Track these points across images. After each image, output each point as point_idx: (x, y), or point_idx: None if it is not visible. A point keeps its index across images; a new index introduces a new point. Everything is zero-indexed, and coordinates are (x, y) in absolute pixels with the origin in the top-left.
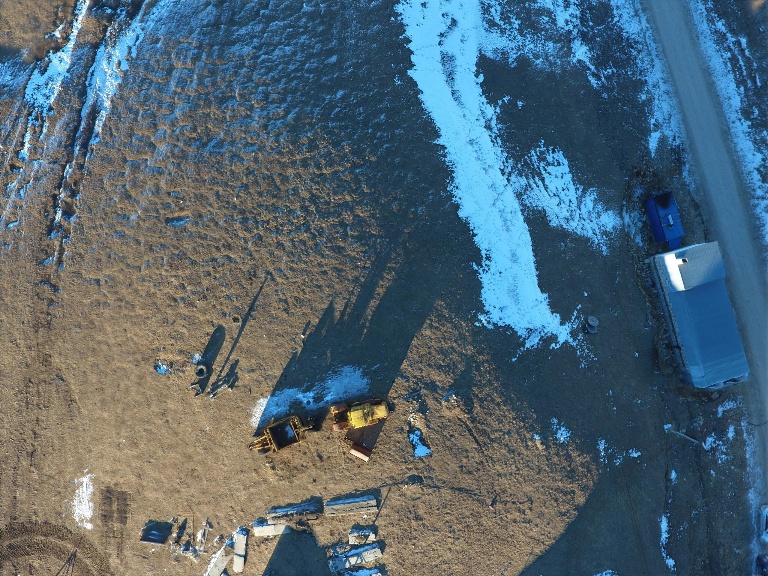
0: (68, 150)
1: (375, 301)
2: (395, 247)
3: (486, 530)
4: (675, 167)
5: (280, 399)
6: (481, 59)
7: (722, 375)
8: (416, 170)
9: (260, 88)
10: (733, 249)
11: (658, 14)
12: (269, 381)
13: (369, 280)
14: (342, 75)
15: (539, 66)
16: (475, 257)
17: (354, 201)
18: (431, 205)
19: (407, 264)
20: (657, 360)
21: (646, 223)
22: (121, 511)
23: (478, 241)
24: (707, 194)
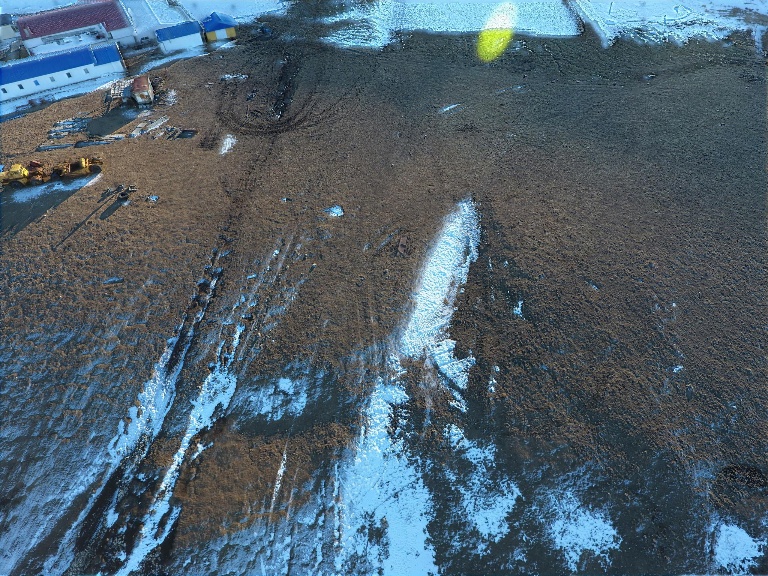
0: (198, 331)
1: None
2: None
3: None
4: None
5: (77, 185)
6: None
7: None
8: None
9: (6, 392)
10: None
11: None
12: (80, 193)
13: None
14: None
15: None
16: None
17: None
18: None
19: None
20: None
21: None
22: (207, 141)
23: None
24: None
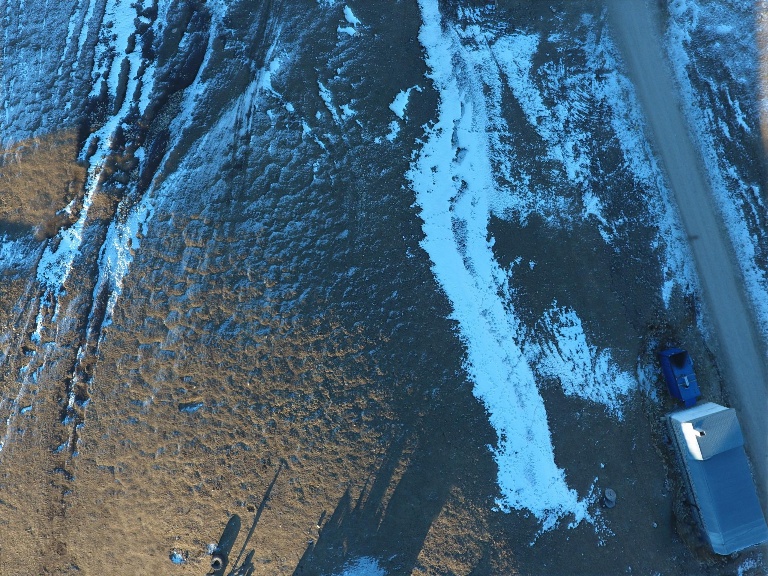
0: (80, 333)
1: (391, 489)
2: (410, 432)
3: None
4: (689, 317)
5: None
6: (492, 221)
7: (742, 542)
8: (430, 349)
9: (272, 267)
10: (750, 402)
11: (669, 159)
12: (285, 572)
13: (384, 467)
14: (353, 251)
15: (550, 224)
16: (491, 438)
17: (368, 385)
18: (445, 386)
19: (422, 450)
20: (676, 527)
21: (661, 376)
22: None
23: (493, 421)
24: (722, 345)
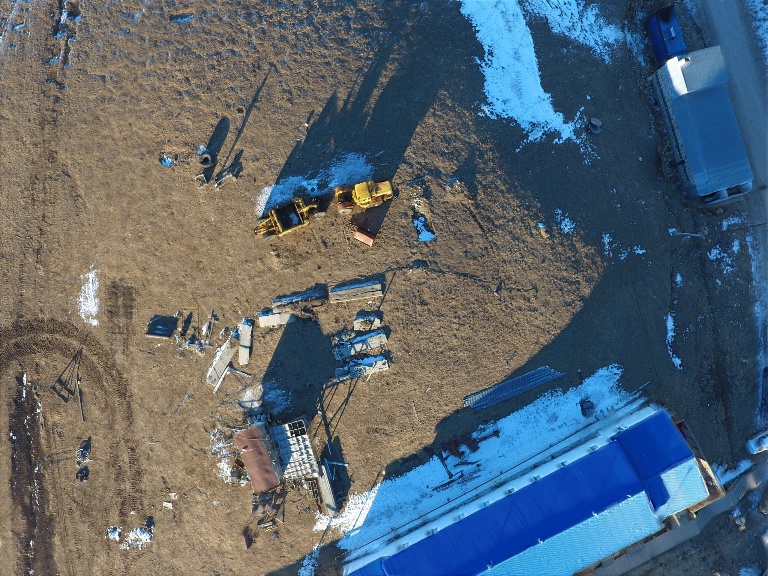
0: None
1: (378, 90)
2: (398, 39)
3: (491, 317)
4: None
5: (284, 187)
6: None
7: (726, 181)
8: None
9: None
10: (735, 70)
11: None
12: (273, 169)
13: (372, 70)
14: None
15: None
16: (478, 51)
17: None
18: (433, 1)
19: (410, 55)
20: (661, 167)
21: (648, 45)
22: (127, 306)
23: (480, 37)
24: (709, 17)
